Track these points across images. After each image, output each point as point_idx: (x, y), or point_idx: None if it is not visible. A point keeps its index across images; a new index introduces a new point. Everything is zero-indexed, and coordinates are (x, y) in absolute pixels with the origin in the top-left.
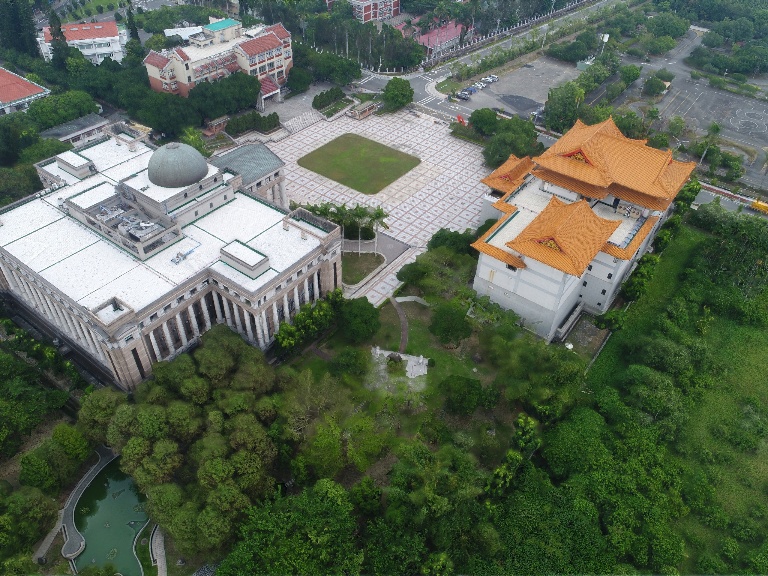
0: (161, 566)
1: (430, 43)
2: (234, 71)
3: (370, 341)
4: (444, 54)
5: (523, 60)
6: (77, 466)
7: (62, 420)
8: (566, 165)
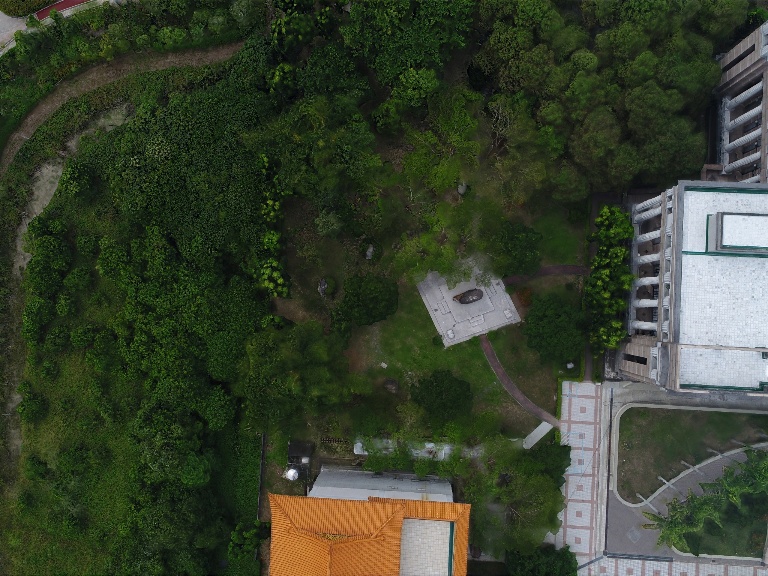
0: None
1: None
2: None
3: None
4: None
5: None
6: None
7: (766, 9)
8: None
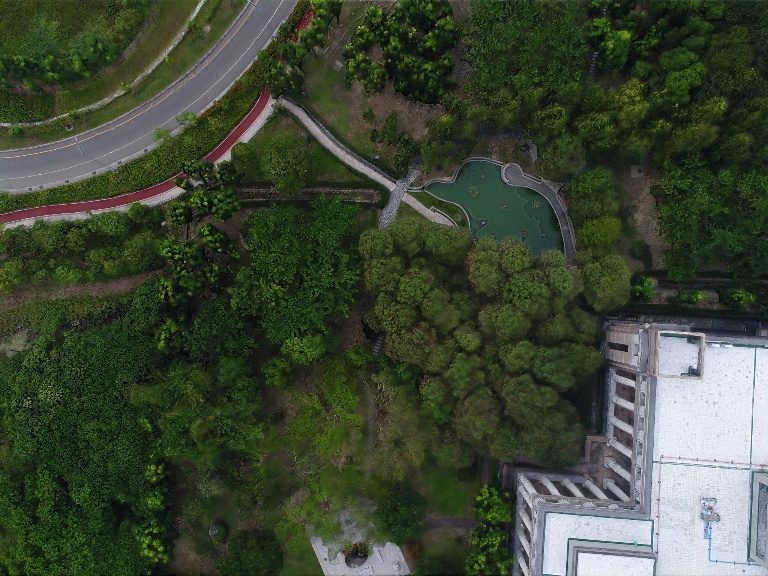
0: (425, 211)
1: None
2: None
3: None
4: None
5: None
6: (575, 222)
7: None
8: None
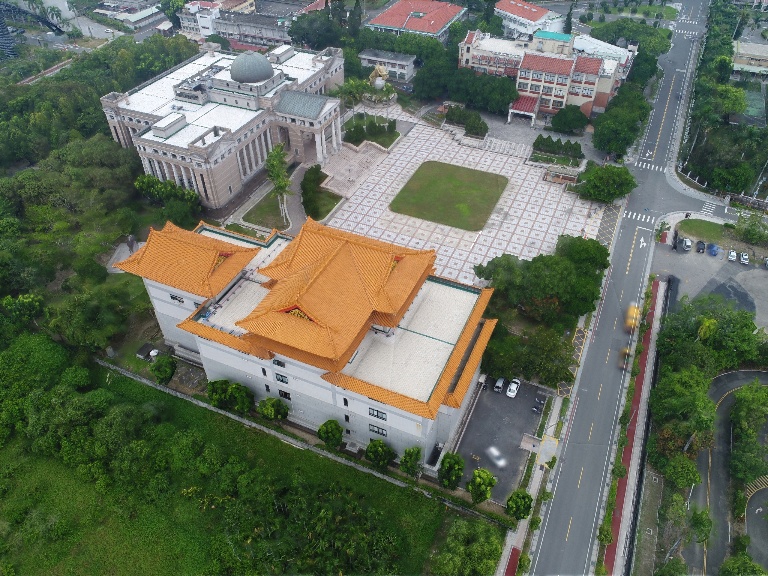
0: None
1: None
2: (513, 76)
3: None
4: None
5: None
6: None
7: None
8: None
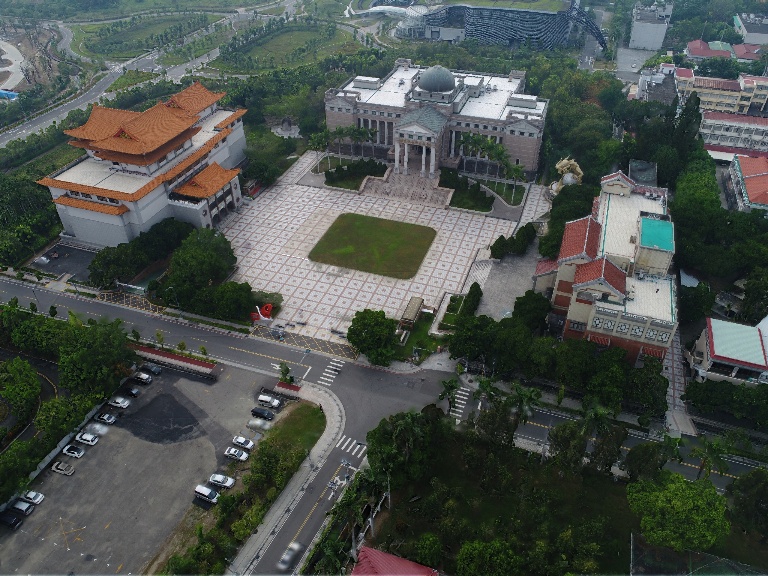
0: None
1: (377, 564)
2: None
3: None
4: None
5: None
6: None
7: None
8: None
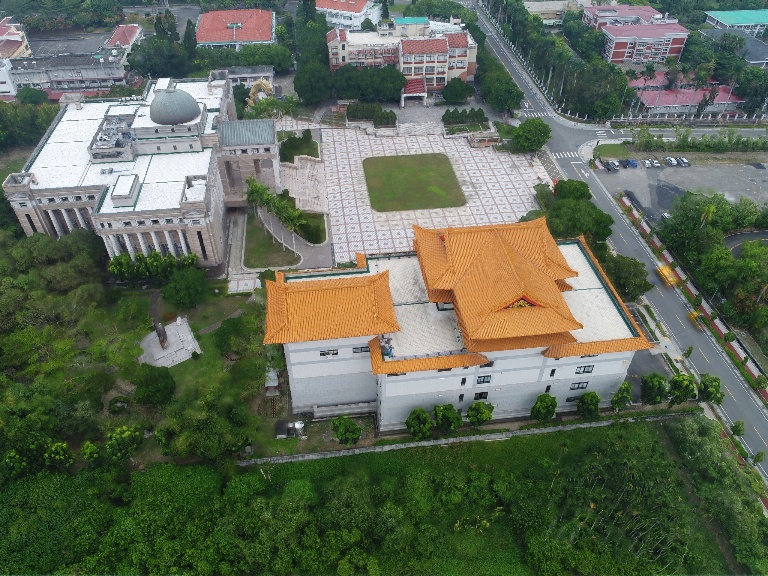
0: None
1: (651, 100)
2: (392, 64)
3: (192, 312)
4: (663, 118)
5: (761, 157)
6: None
7: None
8: (432, 248)
